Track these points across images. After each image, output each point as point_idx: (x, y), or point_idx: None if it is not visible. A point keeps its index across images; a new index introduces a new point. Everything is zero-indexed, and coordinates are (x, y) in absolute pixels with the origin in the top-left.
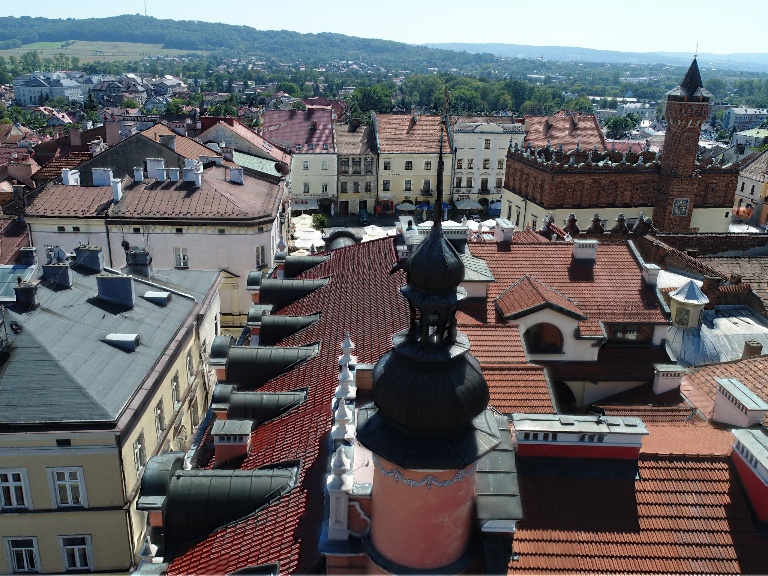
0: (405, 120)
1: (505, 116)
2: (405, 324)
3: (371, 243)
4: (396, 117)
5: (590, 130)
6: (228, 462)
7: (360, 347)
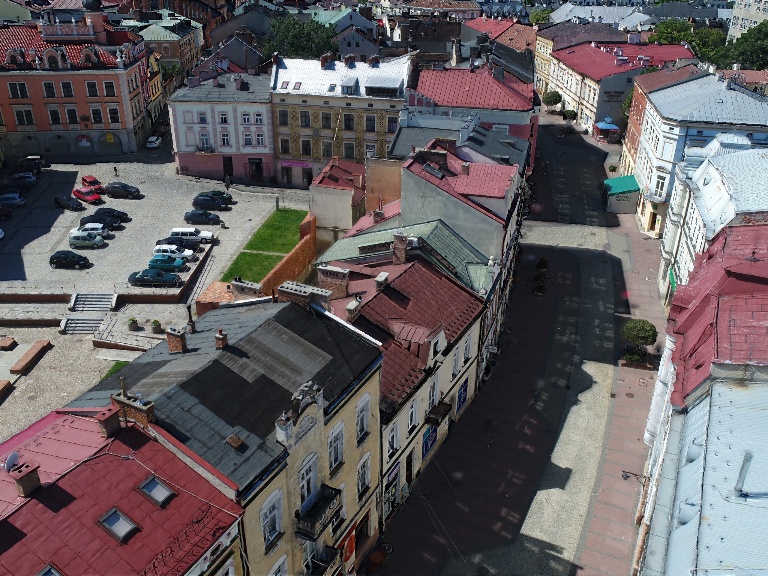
0: None
1: None
2: (6, 31)
3: None
4: None
5: None
6: None
7: (6, 39)
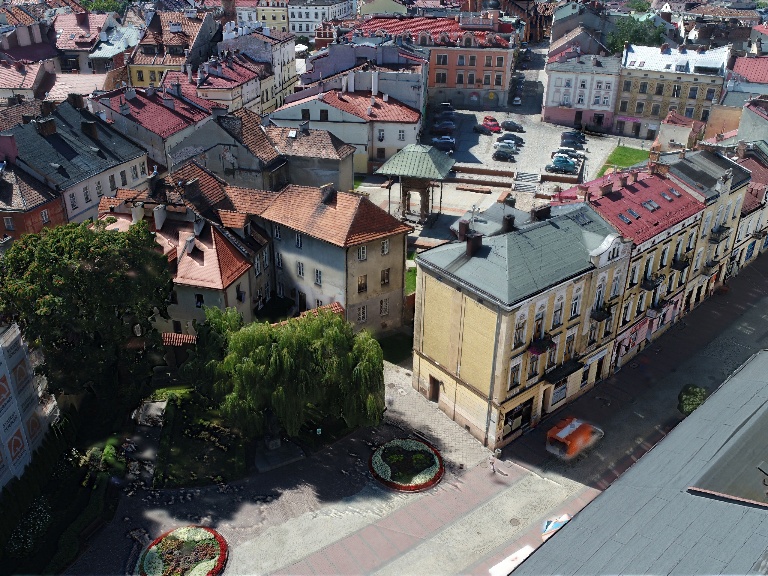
0: (7, 13)
1: (42, 3)
2: None
3: (369, 22)
4: (0, 11)
5: (78, 7)
6: (457, 39)
7: None
